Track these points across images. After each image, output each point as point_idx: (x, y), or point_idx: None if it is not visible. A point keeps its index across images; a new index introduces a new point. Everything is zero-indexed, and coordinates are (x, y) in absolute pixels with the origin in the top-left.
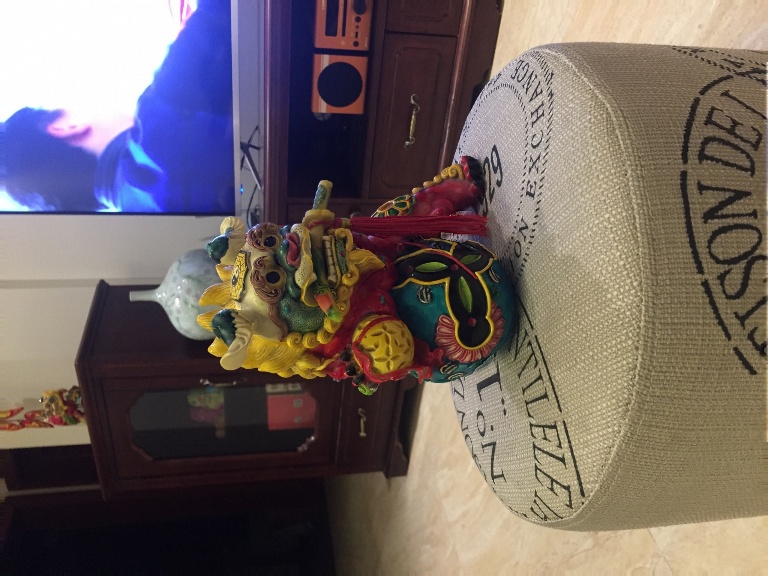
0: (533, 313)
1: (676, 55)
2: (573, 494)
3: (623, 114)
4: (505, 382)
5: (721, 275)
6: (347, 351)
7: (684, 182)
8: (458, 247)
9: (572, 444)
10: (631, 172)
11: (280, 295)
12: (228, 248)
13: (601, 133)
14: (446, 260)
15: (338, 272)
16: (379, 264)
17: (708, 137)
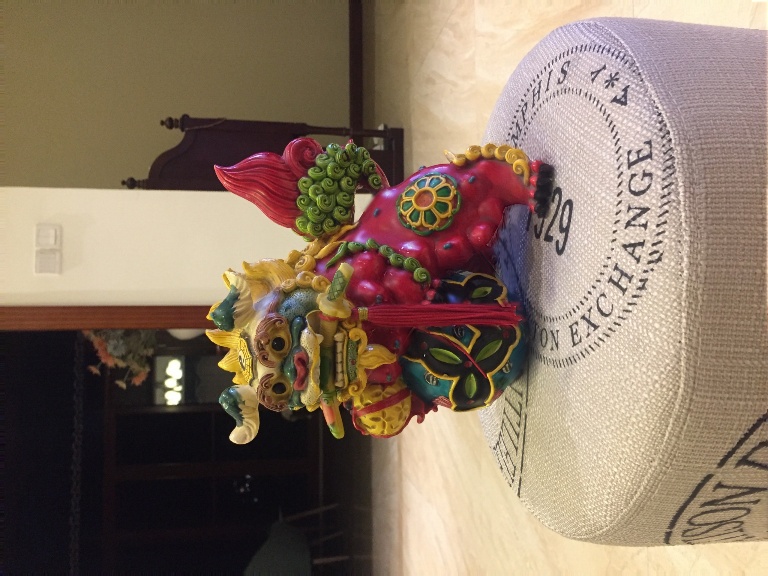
0: (531, 402)
1: None
2: None
3: (690, 406)
4: None
5: (687, 530)
6: None
7: (704, 483)
8: (479, 340)
9: (521, 489)
10: (657, 465)
11: None
12: (234, 328)
13: (655, 409)
14: (462, 354)
15: (346, 380)
16: None
17: (766, 441)
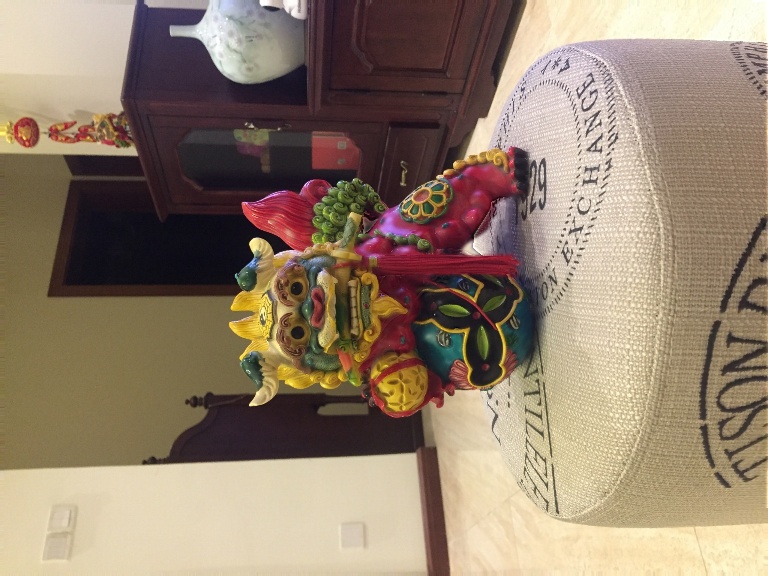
0: (546, 363)
1: (767, 125)
2: (550, 507)
3: (674, 243)
4: (513, 384)
5: (722, 422)
6: (366, 378)
7: (714, 334)
8: (484, 290)
9: (556, 484)
10: (662, 316)
11: (304, 353)
12: (256, 283)
13: (645, 257)
14: (469, 306)
15: (361, 326)
16: (402, 312)
17: (758, 279)
